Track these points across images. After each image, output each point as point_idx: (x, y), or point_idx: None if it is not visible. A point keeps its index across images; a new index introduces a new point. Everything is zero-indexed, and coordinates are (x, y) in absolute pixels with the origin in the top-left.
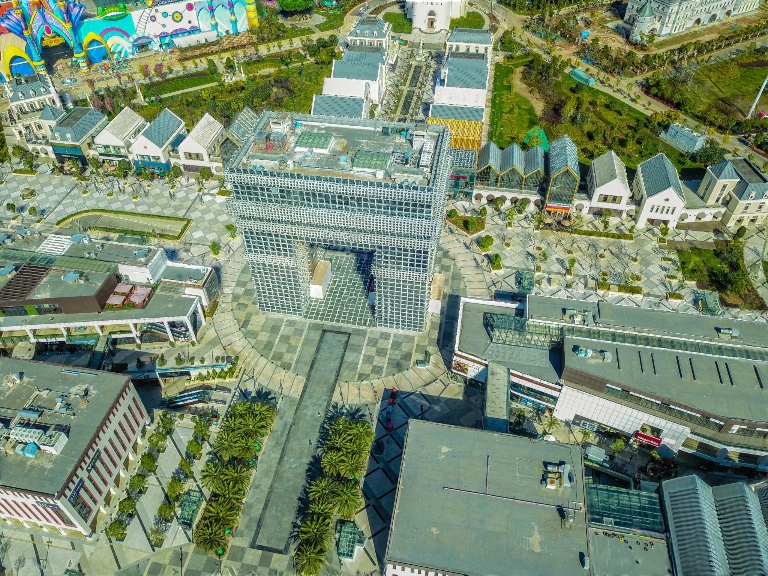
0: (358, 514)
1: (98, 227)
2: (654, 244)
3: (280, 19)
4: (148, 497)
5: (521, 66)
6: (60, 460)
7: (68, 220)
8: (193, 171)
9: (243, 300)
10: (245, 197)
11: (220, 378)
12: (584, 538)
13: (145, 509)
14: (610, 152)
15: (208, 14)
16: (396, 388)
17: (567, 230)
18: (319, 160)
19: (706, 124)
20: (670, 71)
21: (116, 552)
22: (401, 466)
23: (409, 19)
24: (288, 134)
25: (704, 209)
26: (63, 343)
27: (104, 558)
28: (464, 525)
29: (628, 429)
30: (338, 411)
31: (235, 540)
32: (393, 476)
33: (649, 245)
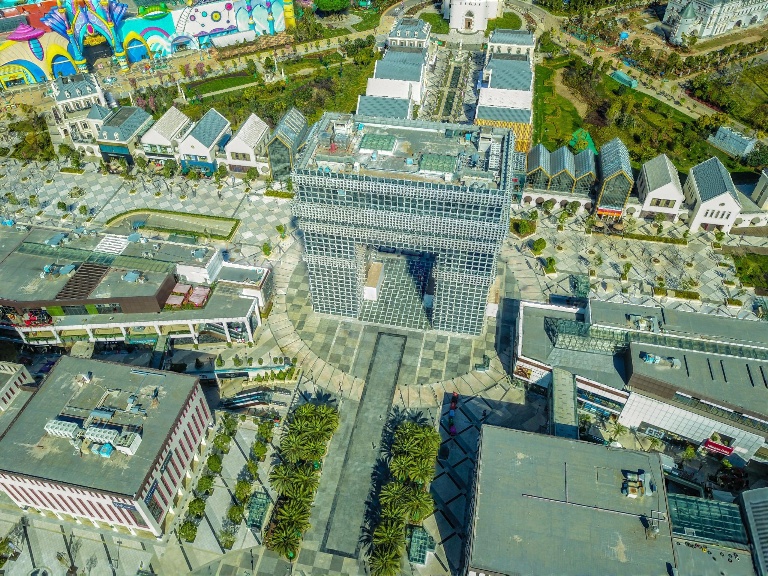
0: (426, 519)
1: (150, 227)
2: (708, 249)
3: None
4: (215, 498)
5: (561, 67)
6: (135, 461)
7: (117, 219)
8: (239, 171)
9: (297, 301)
10: (310, 199)
11: (279, 380)
12: (670, 548)
13: (213, 511)
14: (662, 155)
15: (246, 14)
16: (456, 392)
17: (619, 234)
18: (385, 162)
19: (753, 127)
20: (713, 73)
21: (187, 553)
22: (478, 472)
23: (445, 19)
24: (351, 136)
25: (759, 214)
26: (122, 343)
27: (175, 559)
28: (547, 533)
29: (697, 437)
30: (400, 414)
31: (305, 543)
32: (459, 481)
33: (703, 250)
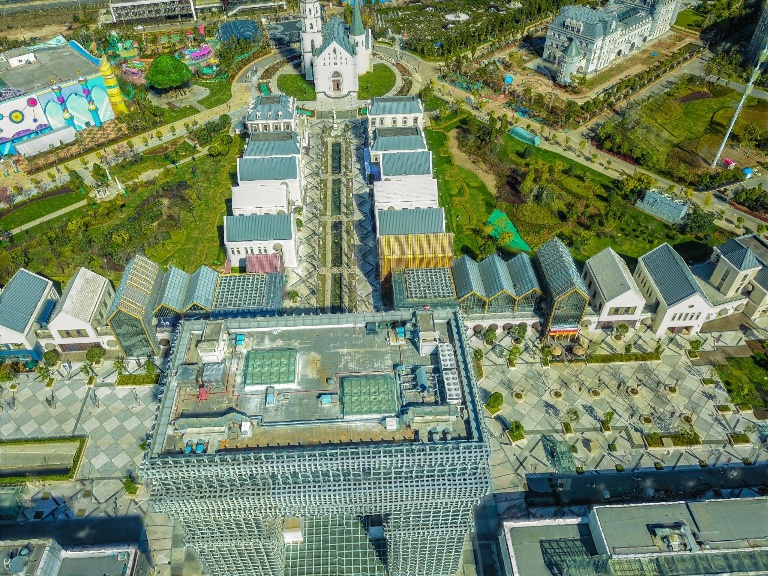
0: None
1: None
2: (685, 360)
3: (152, 97)
4: None
5: (453, 129)
6: None
7: None
8: (75, 350)
9: (188, 571)
10: None
11: None
12: None
13: None
14: (608, 250)
15: (58, 107)
16: None
17: (581, 359)
18: (288, 405)
19: (675, 180)
20: (612, 116)
21: None
22: None
23: (309, 81)
24: (226, 356)
25: (726, 305)
26: None
27: None
28: None
29: None
30: None
31: None
32: None
33: (680, 363)
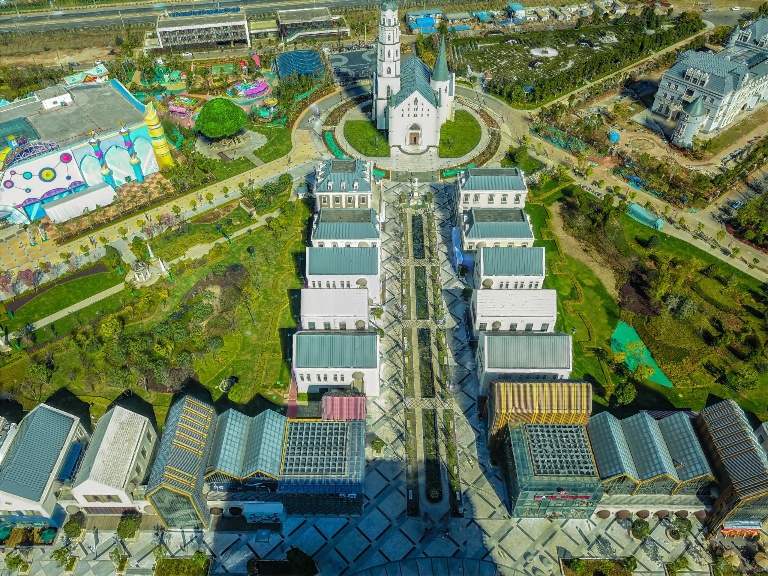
0: None
1: None
2: None
3: (201, 144)
4: None
5: (555, 202)
6: None
7: None
8: (104, 513)
9: None
10: None
11: None
12: None
13: None
14: None
15: (96, 161)
16: None
17: (767, 572)
18: None
19: None
20: (745, 191)
21: None
22: None
23: (380, 131)
24: None
25: None
26: None
27: None
28: None
29: None
30: None
31: None
32: None
33: None
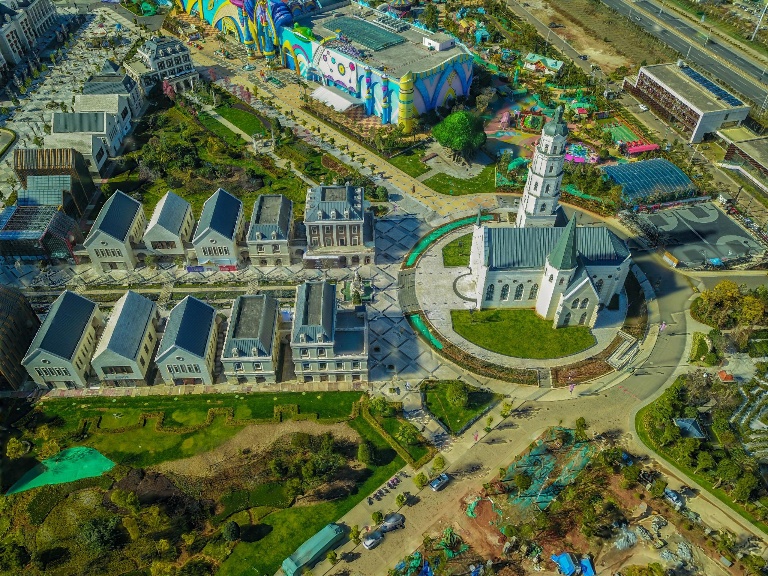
0: None
1: None
2: None
3: None
4: None
5: (357, 432)
6: None
7: (8, 131)
8: None
9: None
10: None
11: None
12: None
13: None
14: None
15: None
16: None
17: None
18: None
19: None
20: None
21: None
22: None
23: None
24: None
25: None
26: None
27: None
28: None
29: None
30: None
31: None
32: None
33: None
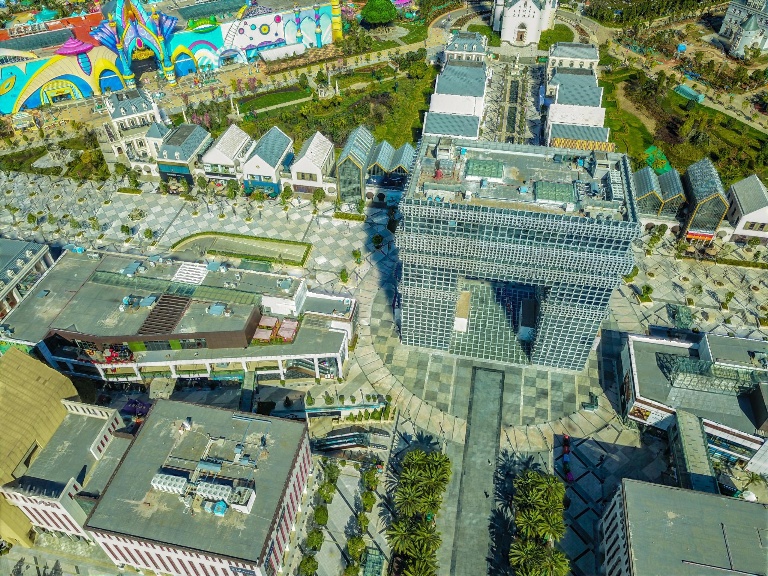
0: None
1: (221, 252)
2: None
3: None
4: (324, 555)
5: (622, 81)
6: (252, 520)
7: (183, 243)
8: (303, 191)
9: (382, 333)
10: (417, 229)
11: (374, 419)
12: None
13: (323, 568)
14: (753, 176)
15: (294, 26)
16: (566, 434)
17: (712, 259)
18: (496, 190)
19: None
20: None
21: None
22: (628, 534)
23: (495, 32)
24: None
25: None
26: (205, 379)
27: None
28: None
29: None
30: (509, 459)
31: None
32: (584, 535)
33: None
